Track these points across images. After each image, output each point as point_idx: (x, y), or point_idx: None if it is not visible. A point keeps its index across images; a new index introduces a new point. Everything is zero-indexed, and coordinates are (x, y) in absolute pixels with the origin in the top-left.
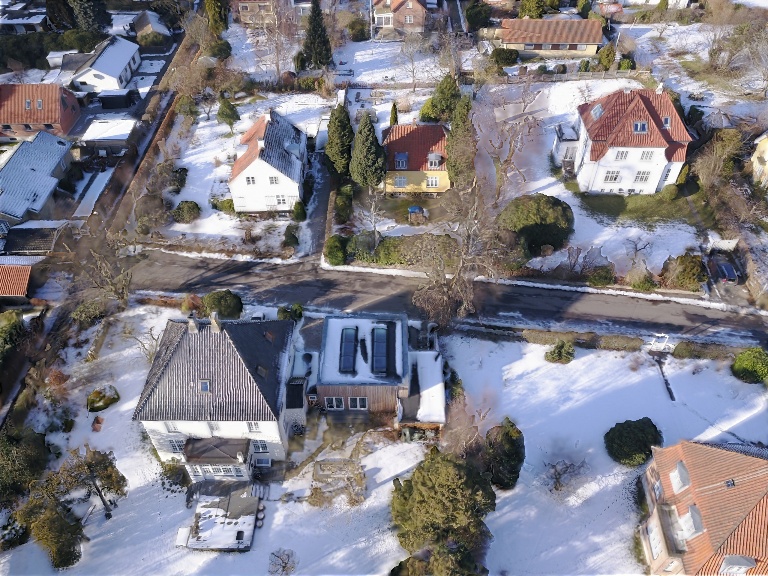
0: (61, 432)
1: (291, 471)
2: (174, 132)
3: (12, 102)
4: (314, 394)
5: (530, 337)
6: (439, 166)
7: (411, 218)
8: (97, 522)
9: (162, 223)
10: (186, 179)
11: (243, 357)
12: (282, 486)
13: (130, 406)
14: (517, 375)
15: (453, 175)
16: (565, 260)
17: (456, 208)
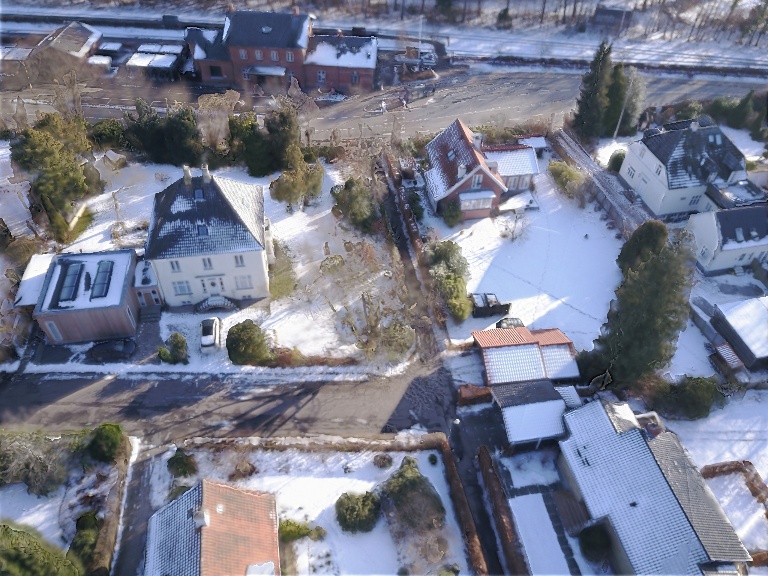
0: None
1: None
2: None
3: None
4: None
5: None
6: None
7: None
8: (295, 205)
9: None
10: None
11: None
12: None
13: None
14: None
15: None
16: None
17: None
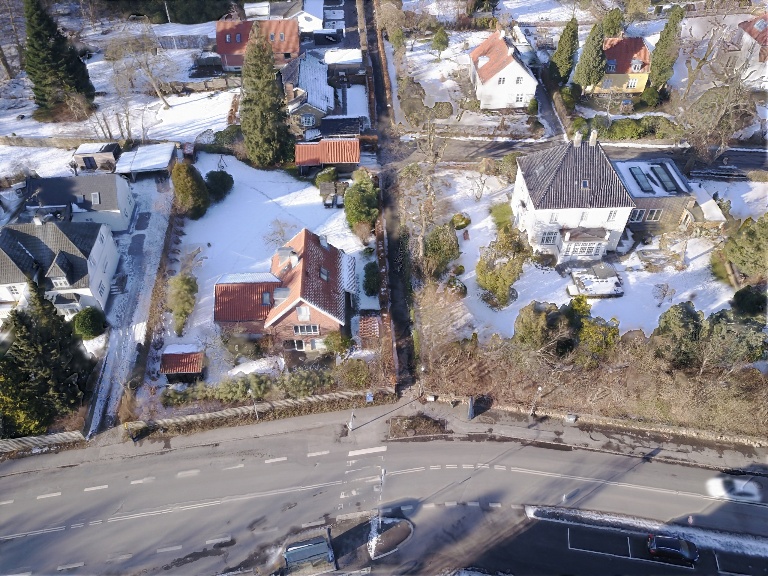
0: None
1: (622, 257)
2: (390, 59)
3: None
4: None
5: (755, 176)
6: (640, 70)
7: None
8: None
9: (427, 118)
10: (424, 90)
11: None
12: (622, 264)
13: (482, 226)
14: (754, 199)
15: (657, 74)
16: (759, 130)
17: (656, 101)
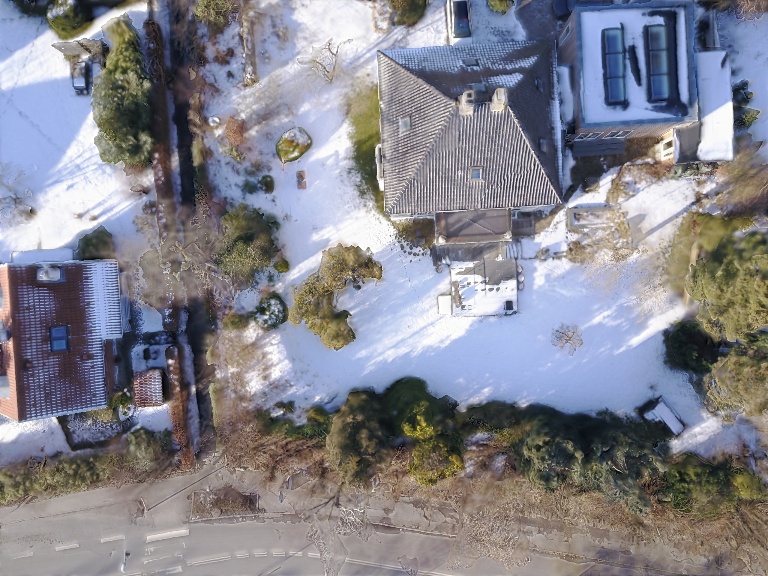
0: (264, 194)
1: (541, 222)
2: None
3: None
4: (570, 133)
5: None
6: None
7: None
8: (348, 294)
9: None
10: None
11: (529, 137)
12: (534, 241)
13: (329, 151)
14: None
15: None
16: None
17: None
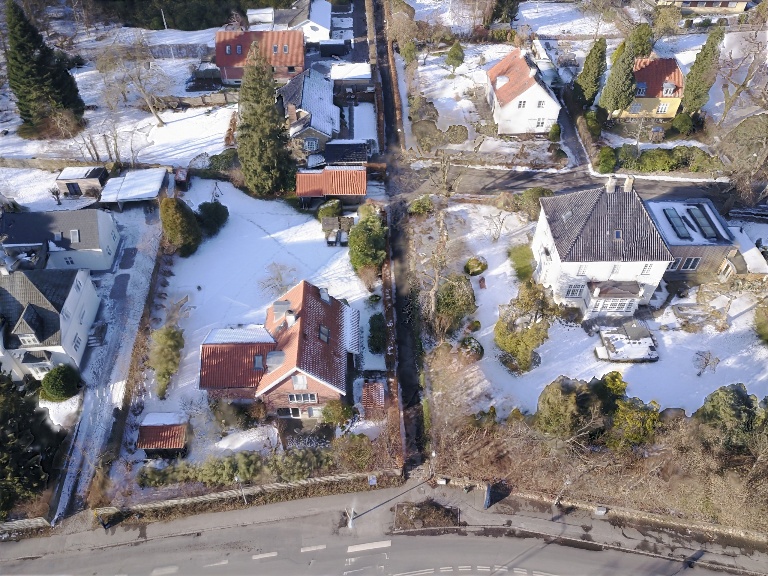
0: None
1: (656, 312)
2: (401, 74)
3: (261, 47)
4: None
5: None
6: (672, 94)
7: (652, 137)
8: None
9: (440, 143)
10: (437, 110)
11: None
12: (655, 321)
13: (500, 271)
14: None
15: (691, 99)
16: None
17: (689, 129)
